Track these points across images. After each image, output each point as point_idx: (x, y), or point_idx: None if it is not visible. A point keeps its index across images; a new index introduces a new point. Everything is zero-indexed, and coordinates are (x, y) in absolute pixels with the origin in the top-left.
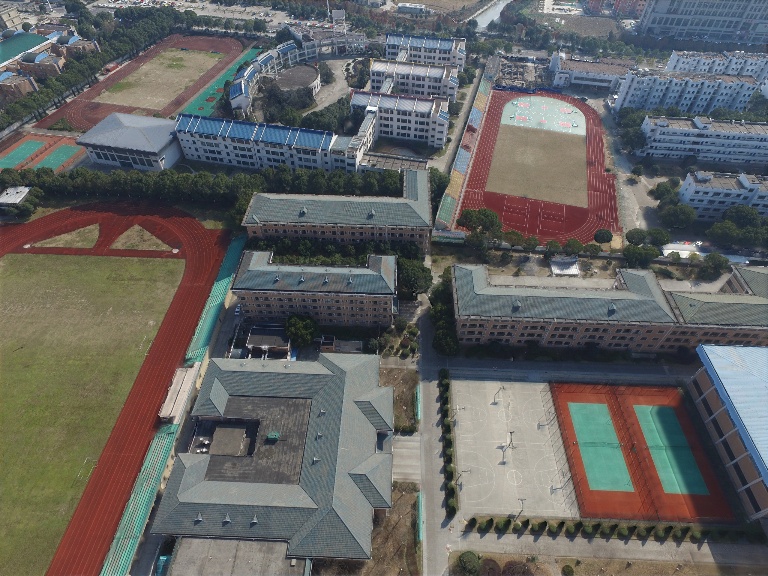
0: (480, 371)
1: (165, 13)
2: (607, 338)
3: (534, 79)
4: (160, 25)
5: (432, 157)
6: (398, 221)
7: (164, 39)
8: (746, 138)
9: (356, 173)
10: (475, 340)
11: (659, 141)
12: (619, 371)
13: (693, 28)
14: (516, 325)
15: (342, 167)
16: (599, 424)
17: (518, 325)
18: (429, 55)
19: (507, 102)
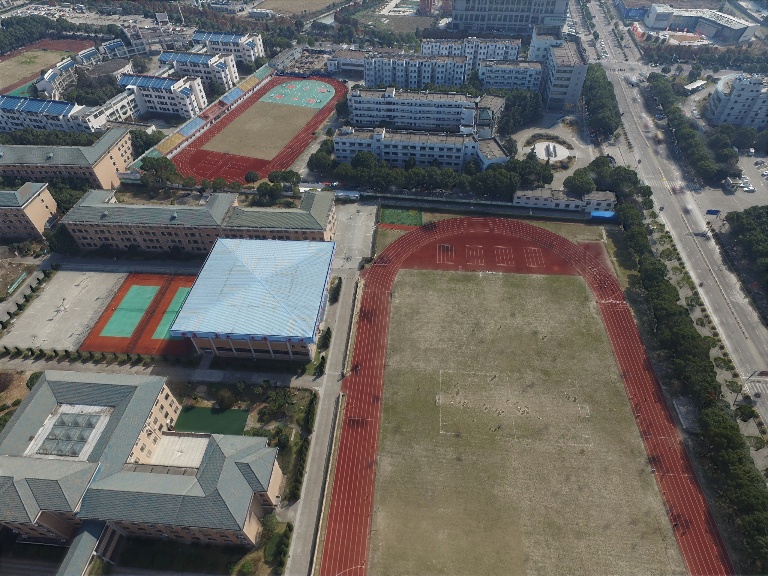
0: (85, 266)
1: (36, 21)
2: (184, 242)
3: (319, 67)
4: (28, 30)
5: (177, 125)
6: (68, 161)
7: (35, 42)
8: (426, 105)
9: (83, 133)
10: (94, 245)
11: (360, 109)
12: (190, 267)
13: (492, 23)
14: (110, 230)
15: (85, 131)
16: (143, 298)
17: (111, 230)
18: (226, 48)
19: (278, 85)
